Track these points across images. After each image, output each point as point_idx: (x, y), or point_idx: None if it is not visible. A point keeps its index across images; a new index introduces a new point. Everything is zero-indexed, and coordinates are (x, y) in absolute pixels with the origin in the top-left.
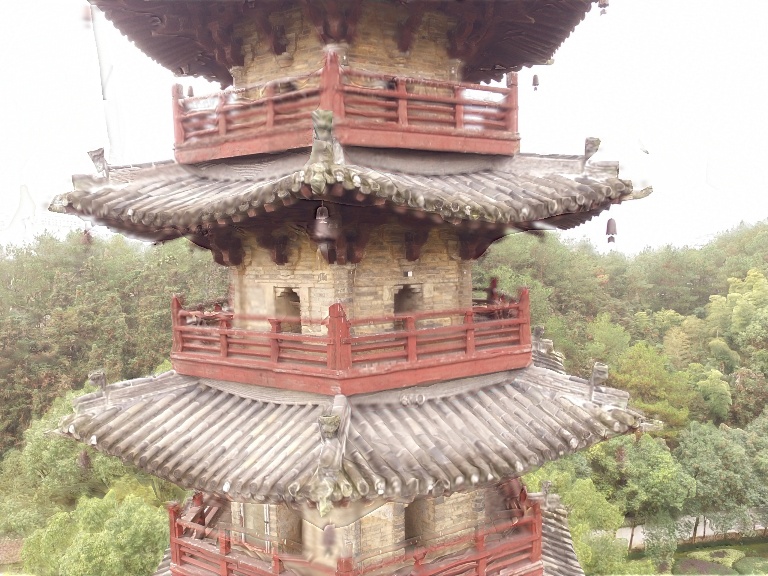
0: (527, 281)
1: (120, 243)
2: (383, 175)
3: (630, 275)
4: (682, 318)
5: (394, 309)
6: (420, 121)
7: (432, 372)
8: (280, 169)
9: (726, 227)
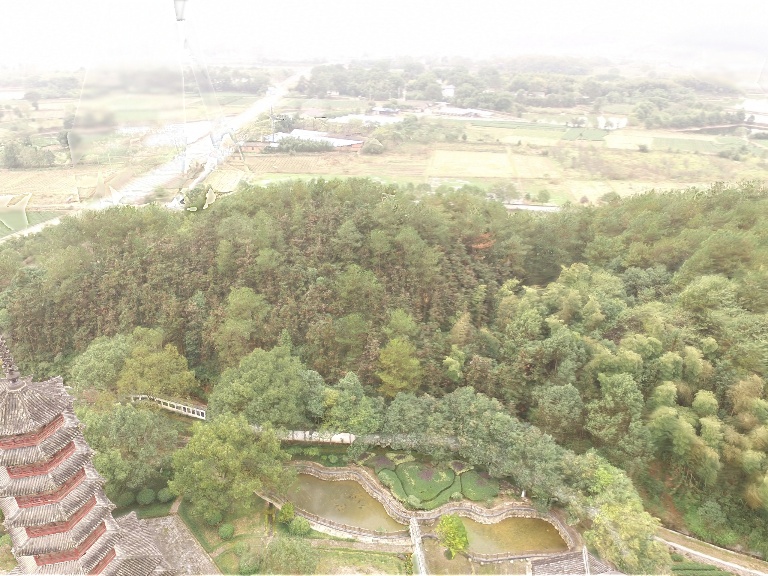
0: (369, 276)
1: (150, 216)
2: (9, 454)
3: (510, 243)
4: (511, 293)
5: None
6: (17, 444)
7: (27, 475)
8: None
9: (642, 192)
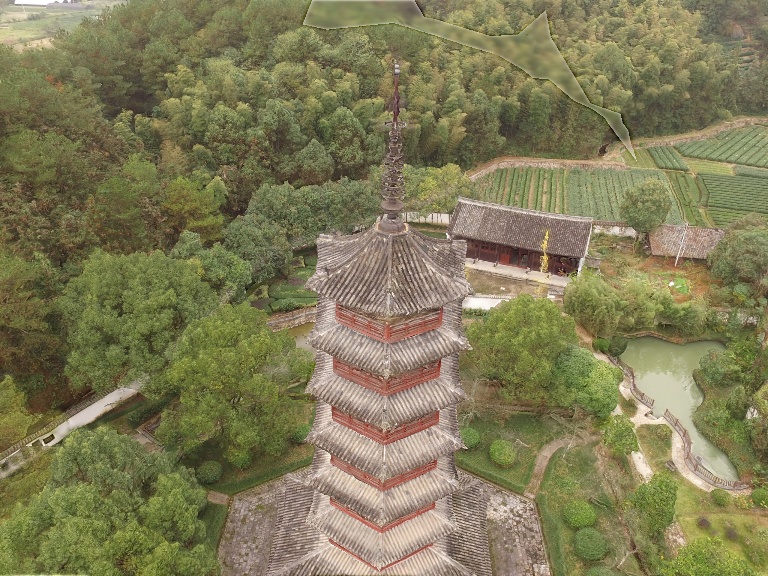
0: (54, 138)
1: None
2: None
3: (80, 78)
4: (148, 120)
5: None
6: None
7: None
8: (419, 333)
9: (121, 1)
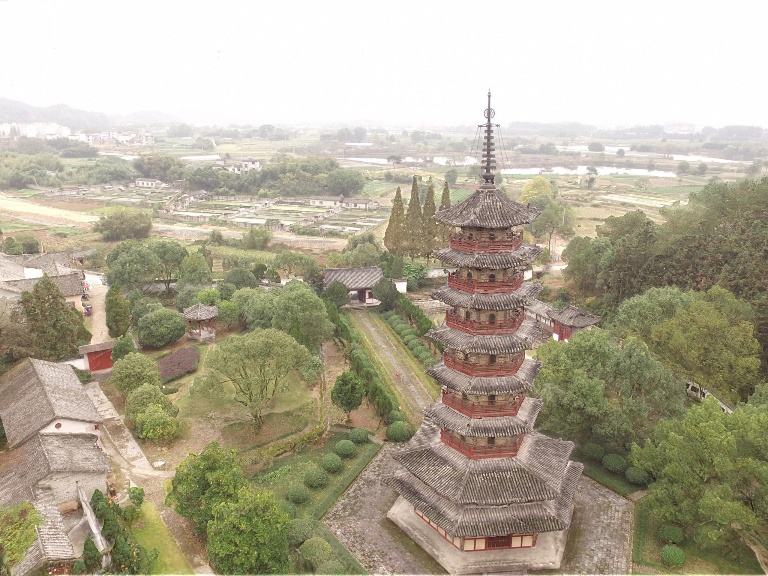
0: None
1: None
2: None
3: None
4: None
5: (468, 276)
6: None
7: None
8: None
9: None
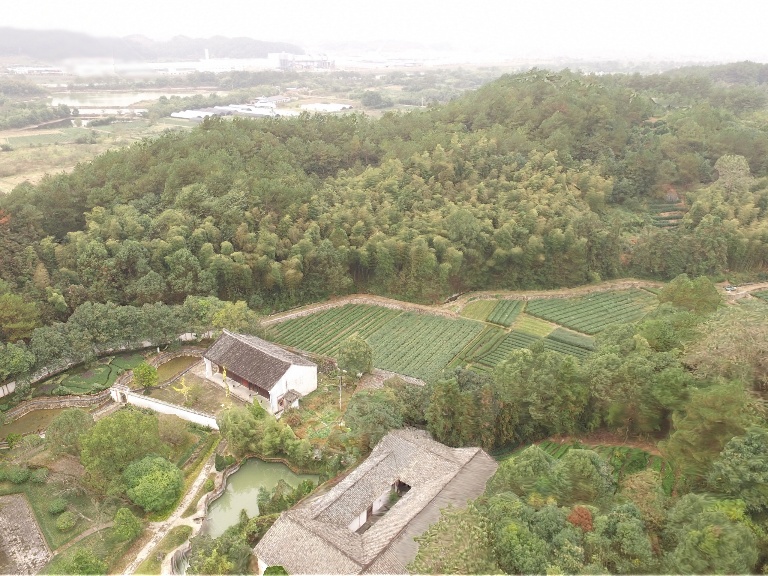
0: None
1: None
2: None
3: (26, 212)
4: (56, 245)
5: None
6: None
7: None
8: None
9: (99, 154)
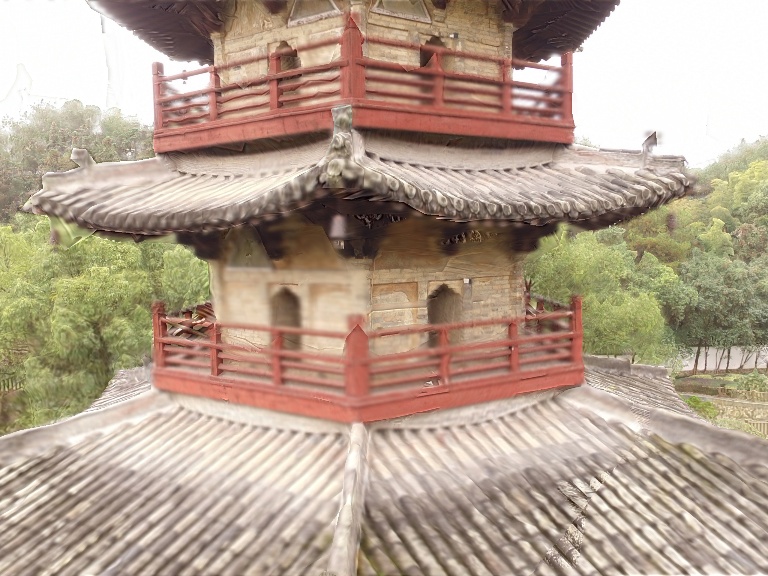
0: None
1: (117, 116)
2: None
3: None
4: None
5: None
6: None
7: None
8: None
9: None
